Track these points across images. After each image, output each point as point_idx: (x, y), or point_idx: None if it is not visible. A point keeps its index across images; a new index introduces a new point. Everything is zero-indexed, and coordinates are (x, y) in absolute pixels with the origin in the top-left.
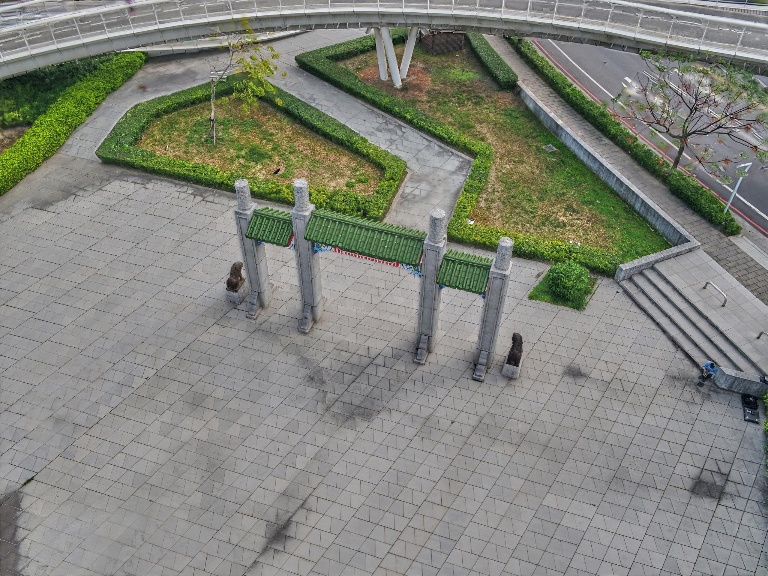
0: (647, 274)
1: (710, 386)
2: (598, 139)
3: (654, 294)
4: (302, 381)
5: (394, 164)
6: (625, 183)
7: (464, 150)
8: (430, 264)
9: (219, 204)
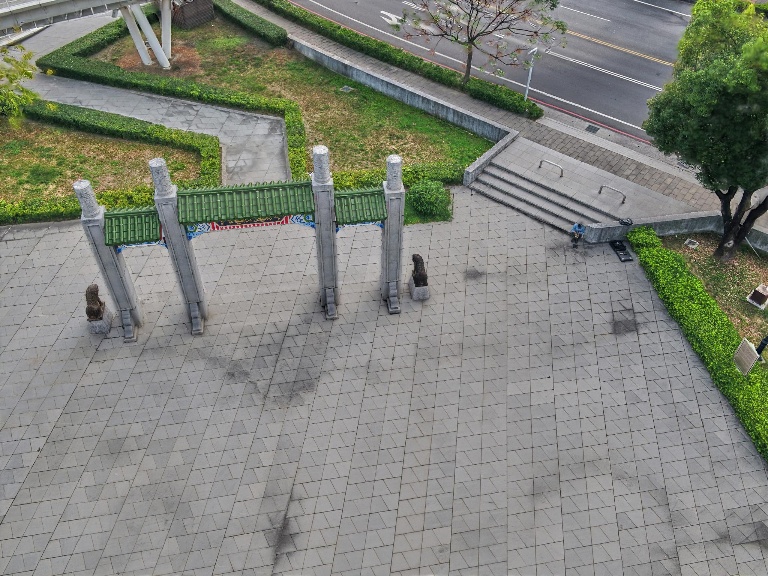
0: (489, 171)
1: (583, 245)
2: (387, 69)
3: (503, 186)
4: (223, 381)
5: (206, 142)
6: (432, 100)
7: (267, 111)
8: (323, 208)
9: (24, 239)
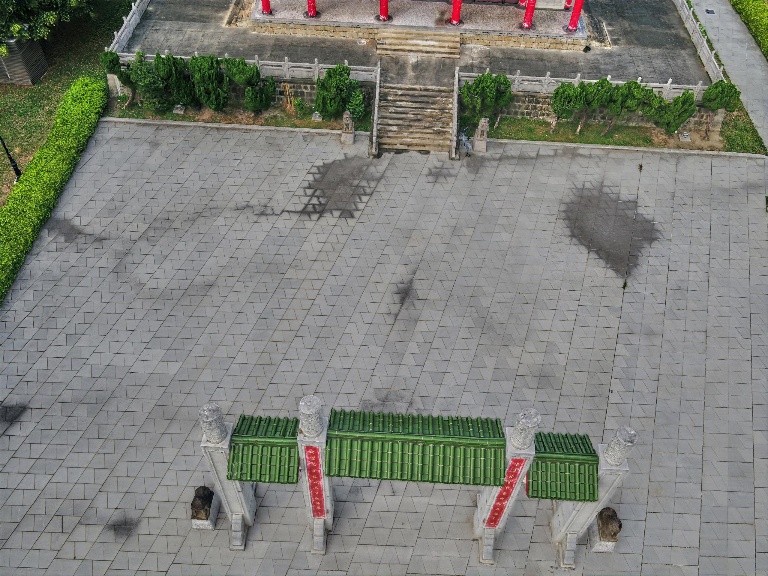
0: None
1: None
2: None
3: None
4: None
5: None
6: None
7: None
8: None
9: None
